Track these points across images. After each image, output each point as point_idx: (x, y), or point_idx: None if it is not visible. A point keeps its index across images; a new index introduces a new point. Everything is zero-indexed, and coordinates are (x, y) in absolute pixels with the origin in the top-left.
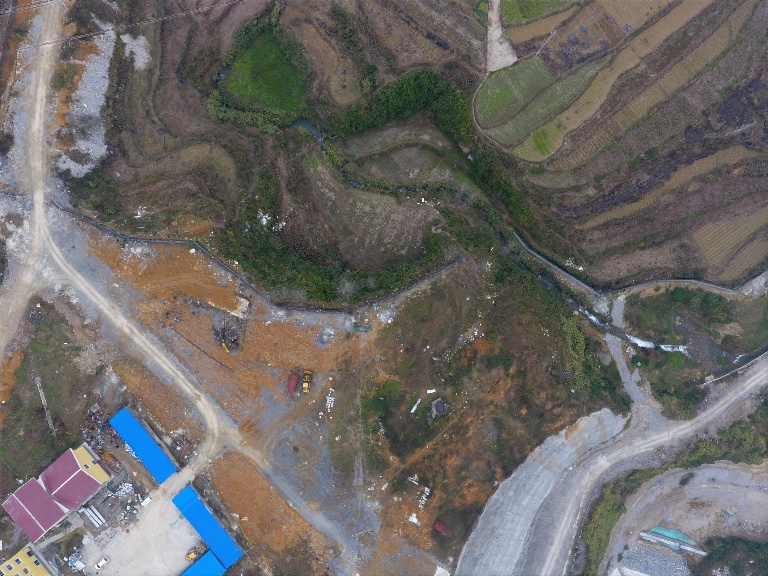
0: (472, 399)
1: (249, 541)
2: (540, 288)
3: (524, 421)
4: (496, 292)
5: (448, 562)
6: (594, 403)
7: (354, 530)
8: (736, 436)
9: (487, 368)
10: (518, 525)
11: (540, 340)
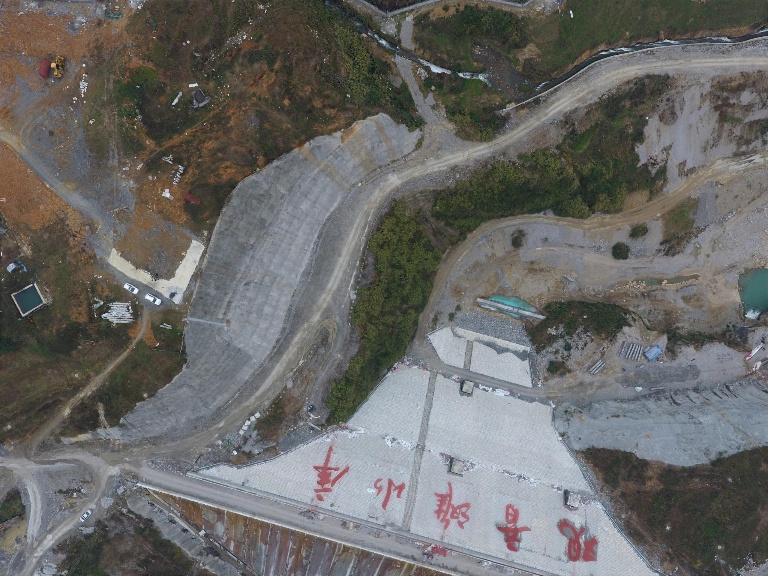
0: (234, 92)
1: (8, 221)
2: (320, 4)
3: (289, 114)
4: (269, 2)
5: (203, 236)
6: (371, 108)
7: (109, 207)
8: (539, 161)
9: (249, 62)
10: (300, 231)
11: (307, 39)
